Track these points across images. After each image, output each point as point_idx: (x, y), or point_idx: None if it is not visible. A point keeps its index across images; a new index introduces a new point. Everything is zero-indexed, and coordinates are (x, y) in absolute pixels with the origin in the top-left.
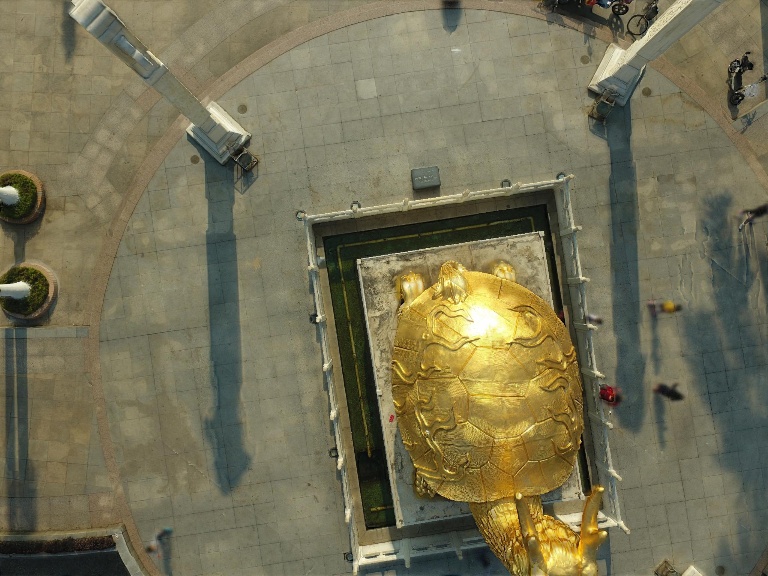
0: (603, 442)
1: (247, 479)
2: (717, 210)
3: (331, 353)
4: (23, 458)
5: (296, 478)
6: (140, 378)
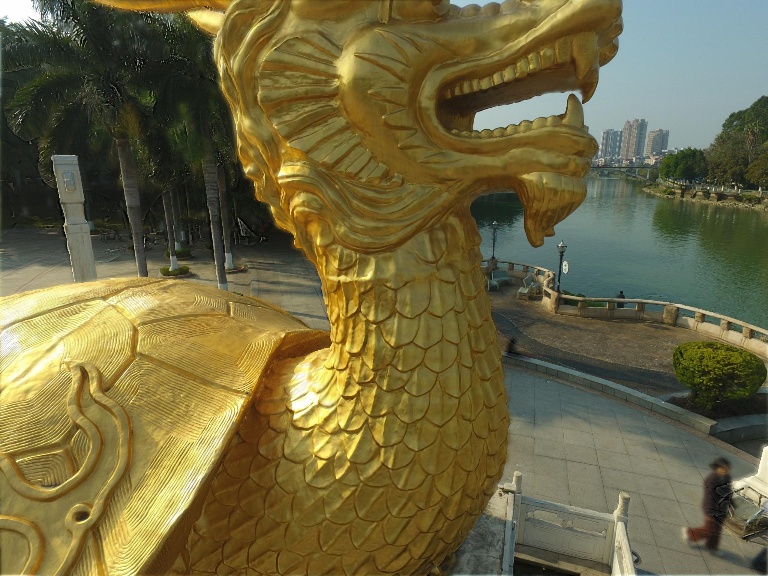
0: None
1: None
2: None
3: None
4: None
5: None
6: None
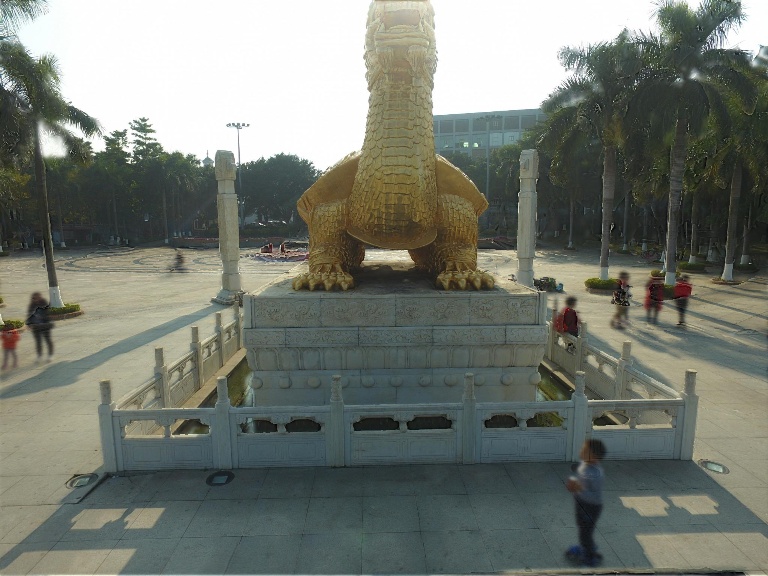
0: None
1: (27, 398)
2: None
3: None
4: None
5: None
6: None
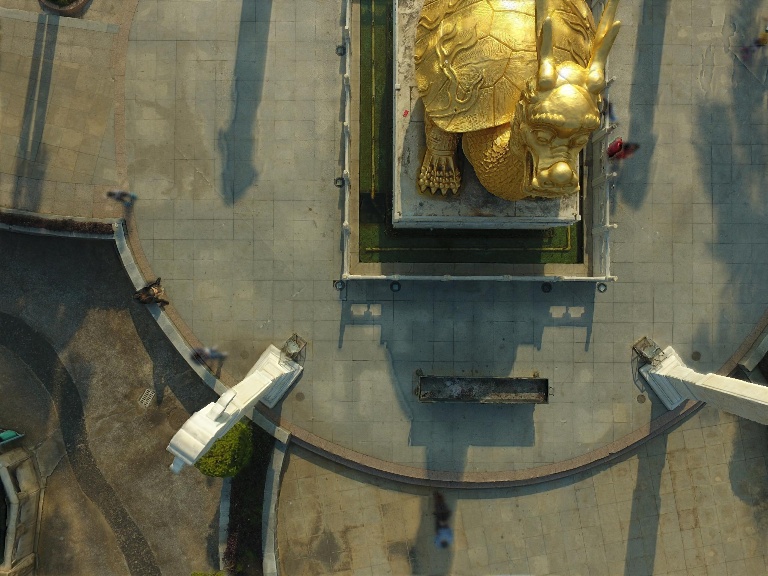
0: (604, 200)
1: (251, 194)
2: (747, 8)
3: (352, 86)
4: (37, 140)
5: (299, 201)
6: (162, 81)
